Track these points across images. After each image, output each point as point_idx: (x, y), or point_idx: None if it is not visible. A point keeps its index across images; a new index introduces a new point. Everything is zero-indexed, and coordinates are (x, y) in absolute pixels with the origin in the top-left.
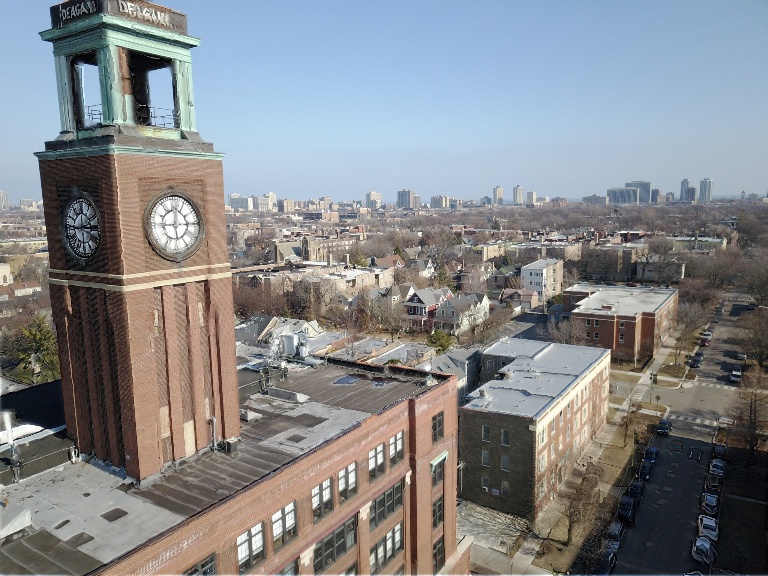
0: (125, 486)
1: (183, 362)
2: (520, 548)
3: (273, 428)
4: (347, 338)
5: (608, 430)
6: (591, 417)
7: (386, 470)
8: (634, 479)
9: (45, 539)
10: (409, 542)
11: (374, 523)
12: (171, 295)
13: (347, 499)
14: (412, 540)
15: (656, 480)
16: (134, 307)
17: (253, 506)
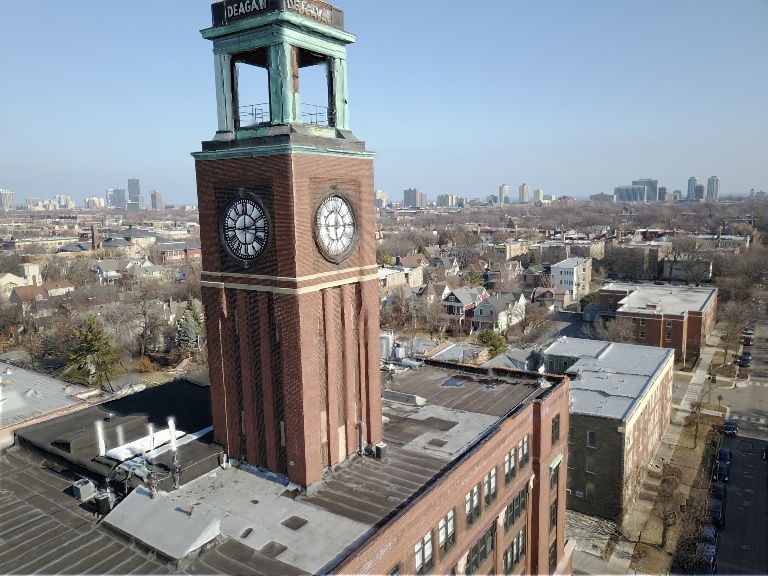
0: (290, 493)
1: (338, 366)
2: (614, 551)
3: (407, 432)
4: (395, 338)
5: (673, 431)
6: (660, 418)
7: (516, 474)
8: (712, 481)
9: (237, 548)
10: (530, 547)
11: (505, 528)
12: (331, 298)
13: (489, 504)
14: (533, 545)
15: (735, 482)
16: (304, 310)
17: (426, 513)
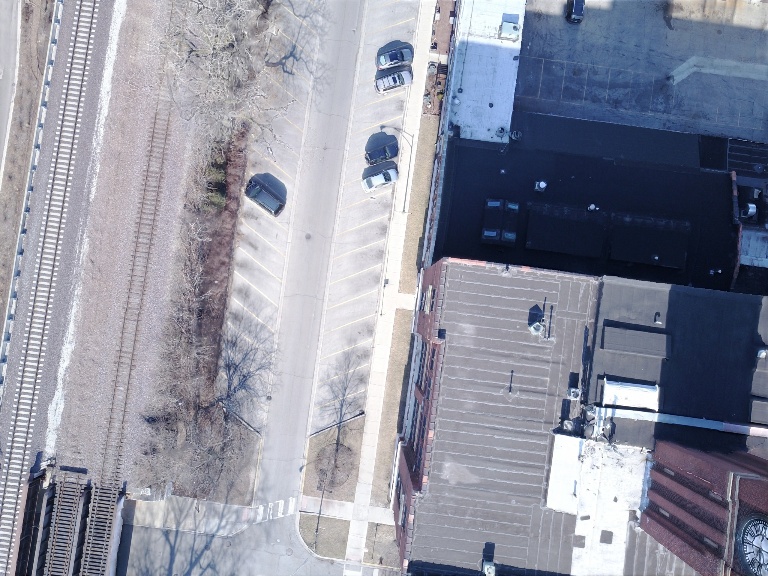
0: (634, 515)
1: None
2: None
3: None
4: None
5: None
6: None
7: None
8: None
9: (571, 522)
10: None
11: None
12: None
13: None
14: None
15: None
16: None
17: None
